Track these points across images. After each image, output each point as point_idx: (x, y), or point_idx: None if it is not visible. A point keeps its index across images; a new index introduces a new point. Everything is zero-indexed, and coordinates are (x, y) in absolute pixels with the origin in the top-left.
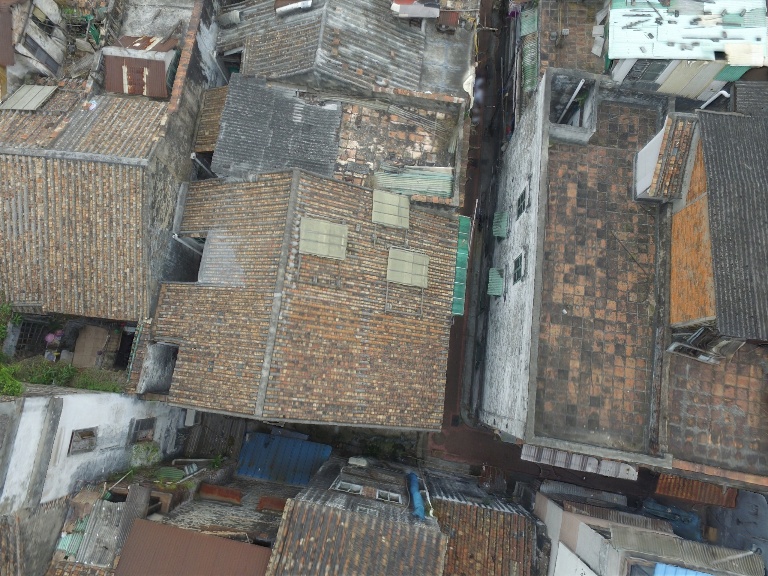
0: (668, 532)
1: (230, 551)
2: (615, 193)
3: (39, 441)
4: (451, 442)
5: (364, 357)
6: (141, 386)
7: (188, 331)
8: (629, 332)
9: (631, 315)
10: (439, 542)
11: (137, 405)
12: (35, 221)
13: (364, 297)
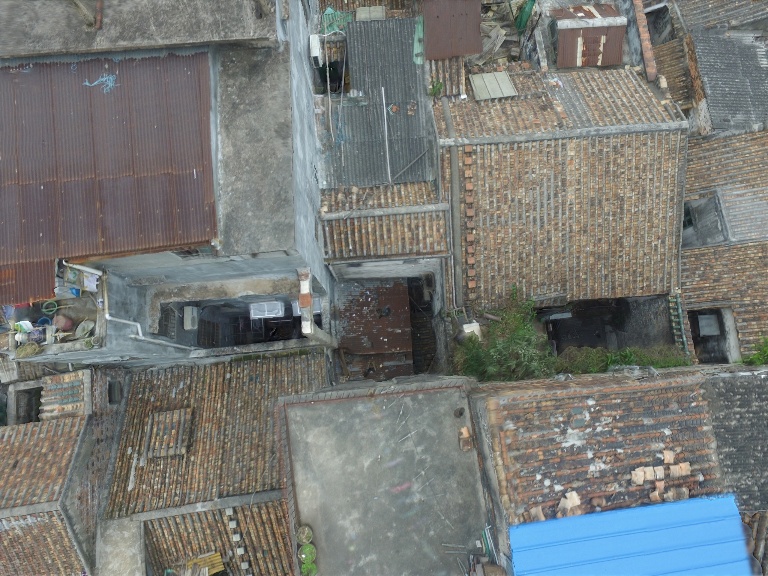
0: None
1: None
2: None
3: None
4: None
5: None
6: None
7: (735, 292)
8: None
9: None
10: None
11: None
12: (562, 207)
13: None
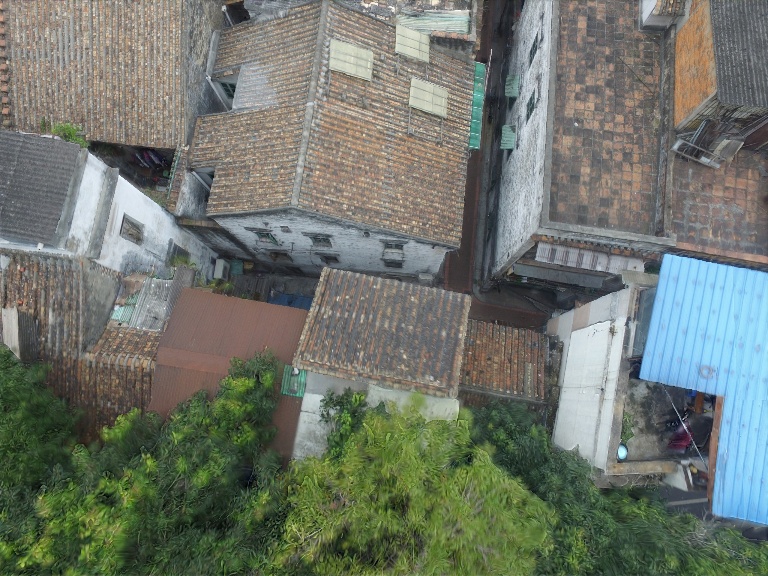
0: None
1: (272, 311)
2: (622, 25)
3: (98, 202)
4: None
5: (389, 172)
6: (179, 208)
7: (224, 153)
8: (636, 142)
9: (638, 127)
10: (464, 300)
11: (175, 229)
12: (80, 50)
13: (388, 119)
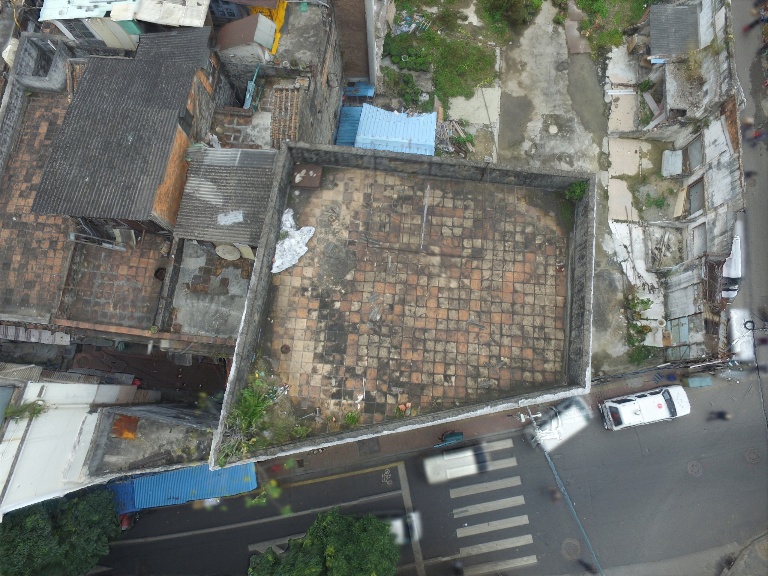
0: (93, 383)
1: None
2: None
3: None
4: (93, 364)
5: None
6: None
7: None
8: (62, 231)
9: (66, 218)
10: None
11: None
12: None
13: None
